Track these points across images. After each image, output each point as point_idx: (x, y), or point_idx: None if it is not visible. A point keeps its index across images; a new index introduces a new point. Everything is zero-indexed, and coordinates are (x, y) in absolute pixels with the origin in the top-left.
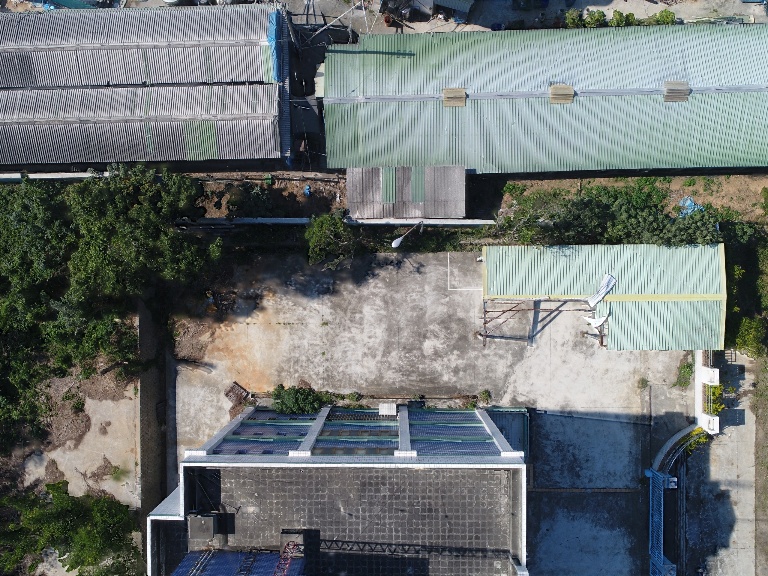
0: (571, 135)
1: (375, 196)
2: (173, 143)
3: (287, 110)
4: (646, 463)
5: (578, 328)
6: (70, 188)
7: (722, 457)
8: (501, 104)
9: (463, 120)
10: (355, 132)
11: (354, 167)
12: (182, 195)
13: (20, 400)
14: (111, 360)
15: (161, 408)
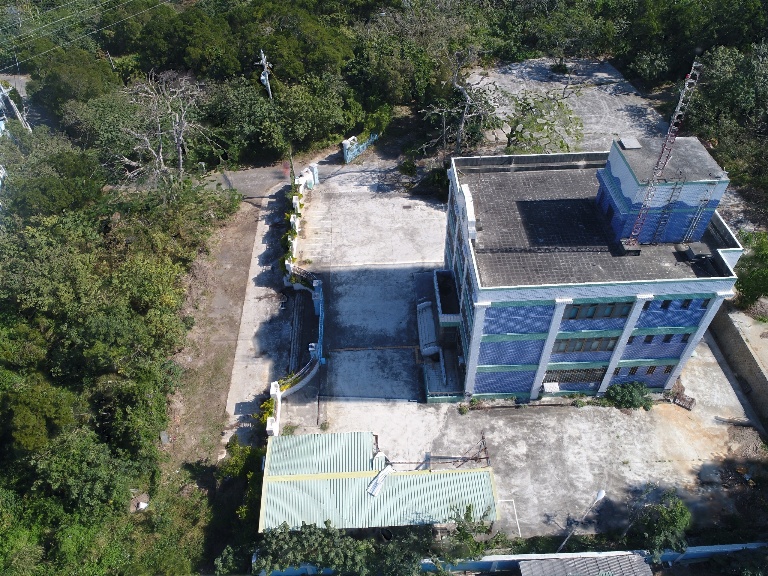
0: None
1: None
2: None
3: None
4: (324, 369)
5: None
6: None
7: (258, 379)
8: None
9: None
10: None
11: None
12: None
13: None
14: None
15: (746, 388)
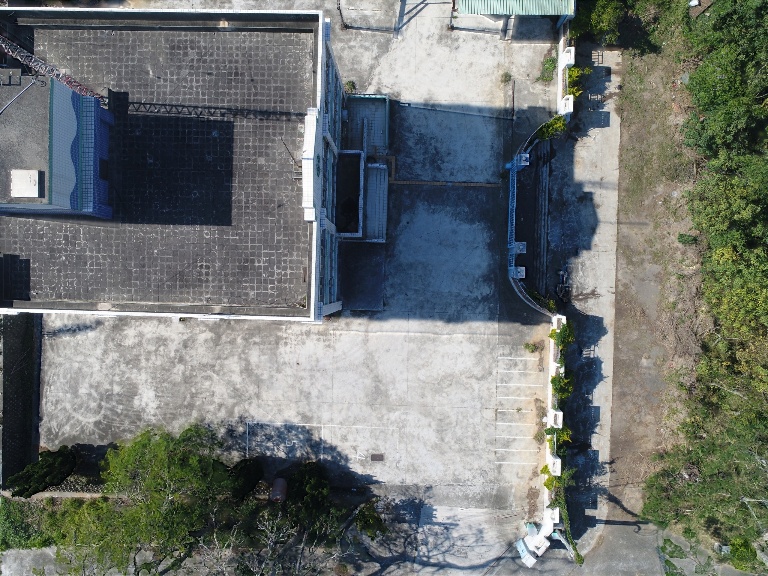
0: None
1: None
2: None
3: None
4: (507, 158)
5: (444, 21)
6: None
7: (586, 159)
8: None
9: None
10: None
11: None
12: None
13: None
14: None
15: None
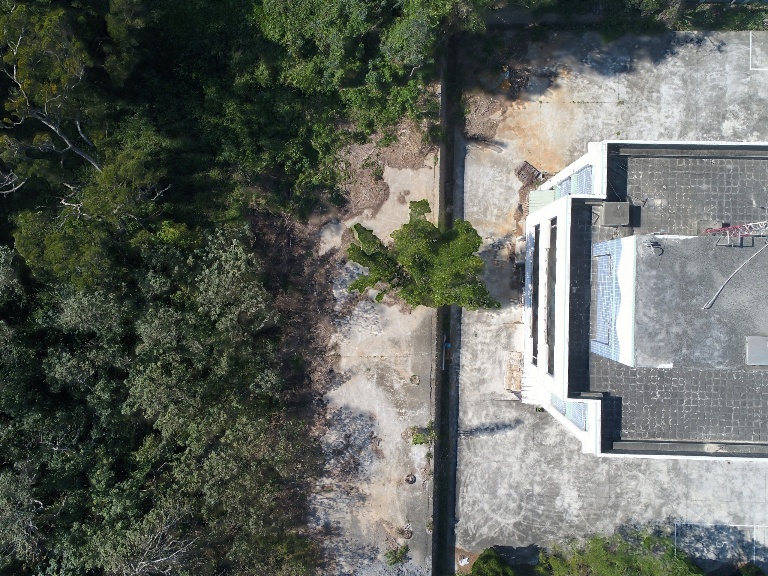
0: None
1: None
2: None
3: None
4: None
5: None
6: None
7: None
8: None
9: None
10: None
11: None
12: None
13: (320, 166)
14: (416, 125)
15: (449, 187)
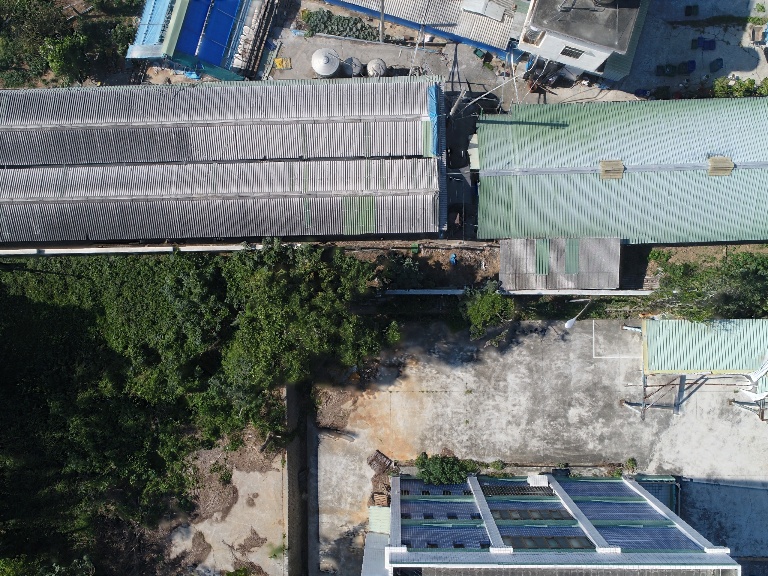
0: (727, 206)
1: (528, 267)
2: (331, 218)
3: (444, 183)
4: None
5: (724, 396)
6: (218, 259)
7: None
8: (658, 176)
9: (619, 192)
10: (508, 203)
11: (505, 237)
12: (361, 280)
13: (168, 472)
14: (260, 432)
15: (303, 476)
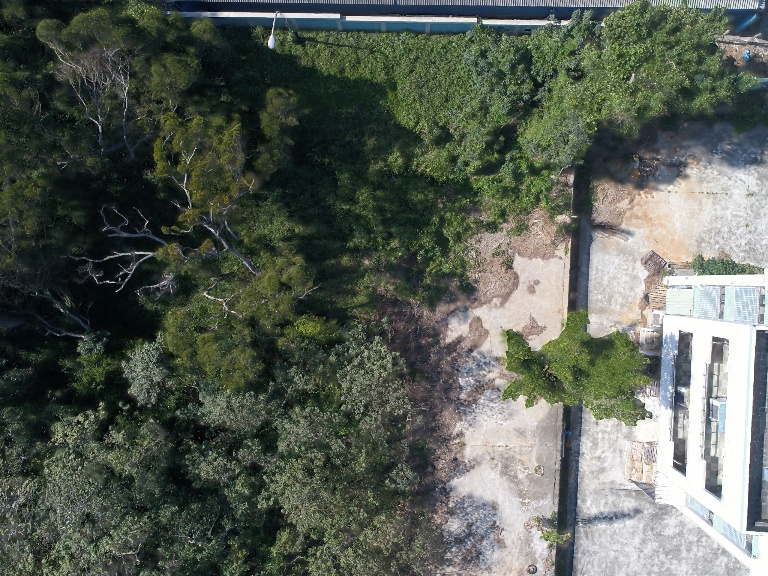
0: None
1: None
2: None
3: None
4: None
5: None
6: (514, 39)
7: None
8: None
9: None
10: None
11: None
12: (718, 23)
13: (450, 254)
14: (549, 216)
15: (573, 275)
